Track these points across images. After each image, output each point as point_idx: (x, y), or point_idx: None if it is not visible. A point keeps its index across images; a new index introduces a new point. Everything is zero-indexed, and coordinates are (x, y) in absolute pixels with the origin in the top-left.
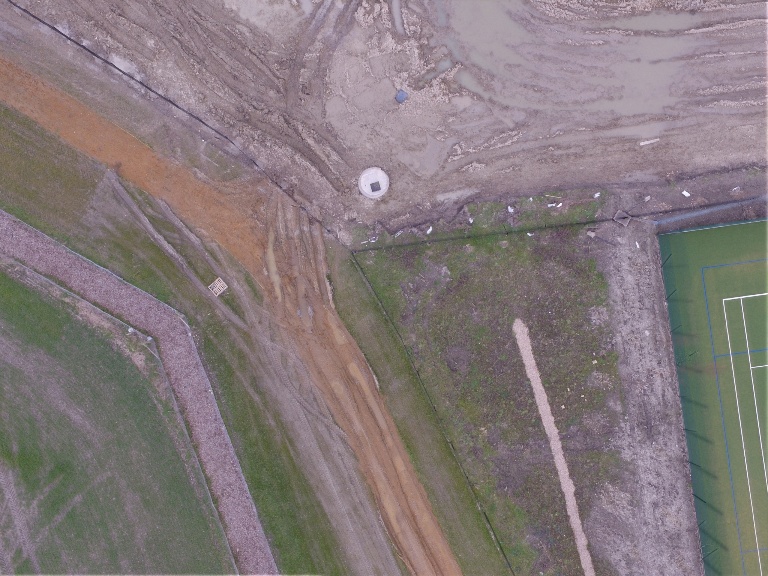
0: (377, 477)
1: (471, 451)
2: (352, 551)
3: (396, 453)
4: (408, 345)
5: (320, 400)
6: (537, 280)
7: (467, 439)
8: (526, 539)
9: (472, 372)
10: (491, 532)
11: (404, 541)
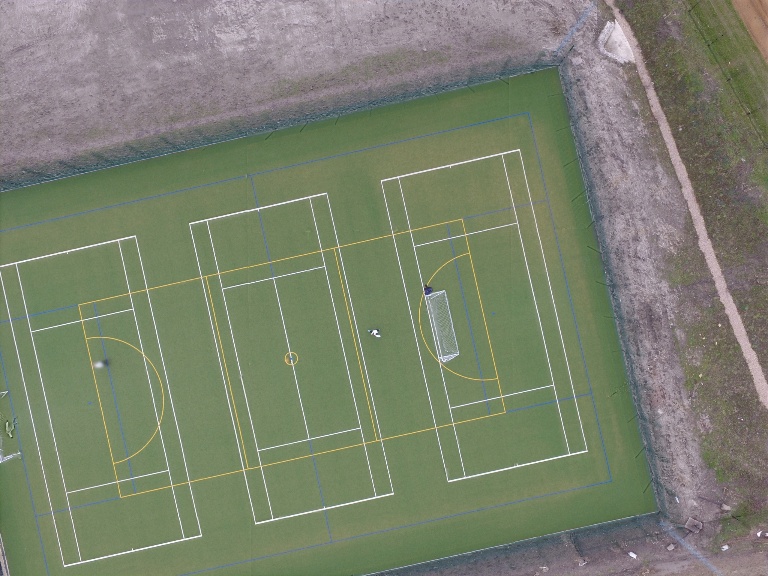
0: None
1: None
2: None
3: None
4: None
5: None
6: (766, 454)
7: None
8: (762, 193)
9: None
10: None
11: None
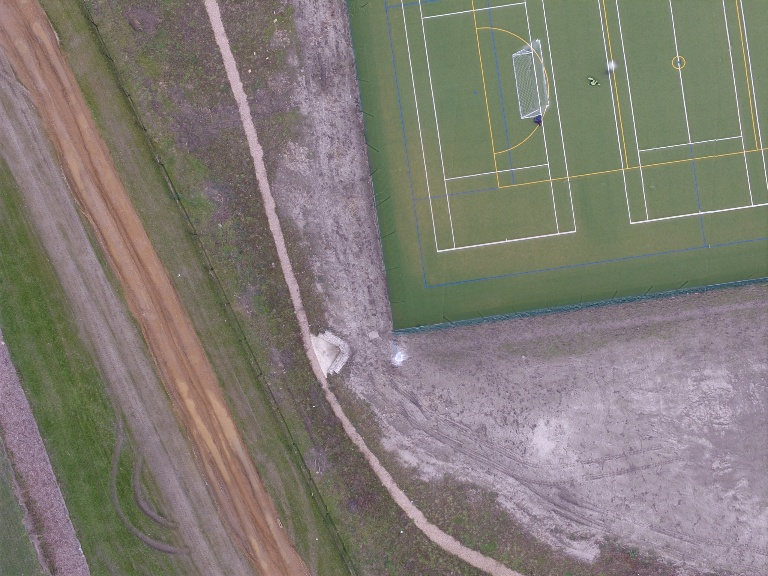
0: (61, 135)
1: (150, 105)
2: (37, 208)
3: (79, 111)
4: (88, 2)
5: (3, 58)
6: None
7: (145, 92)
8: (205, 192)
9: (158, 35)
10: (170, 184)
11: (87, 197)
